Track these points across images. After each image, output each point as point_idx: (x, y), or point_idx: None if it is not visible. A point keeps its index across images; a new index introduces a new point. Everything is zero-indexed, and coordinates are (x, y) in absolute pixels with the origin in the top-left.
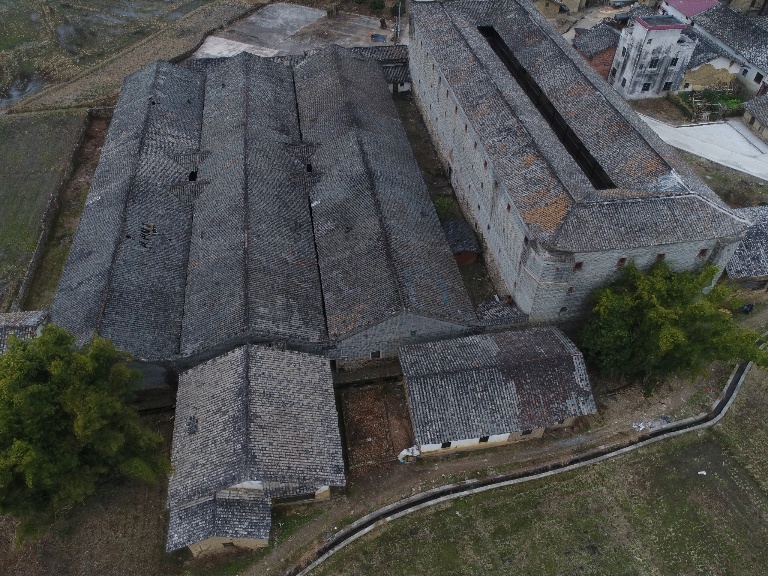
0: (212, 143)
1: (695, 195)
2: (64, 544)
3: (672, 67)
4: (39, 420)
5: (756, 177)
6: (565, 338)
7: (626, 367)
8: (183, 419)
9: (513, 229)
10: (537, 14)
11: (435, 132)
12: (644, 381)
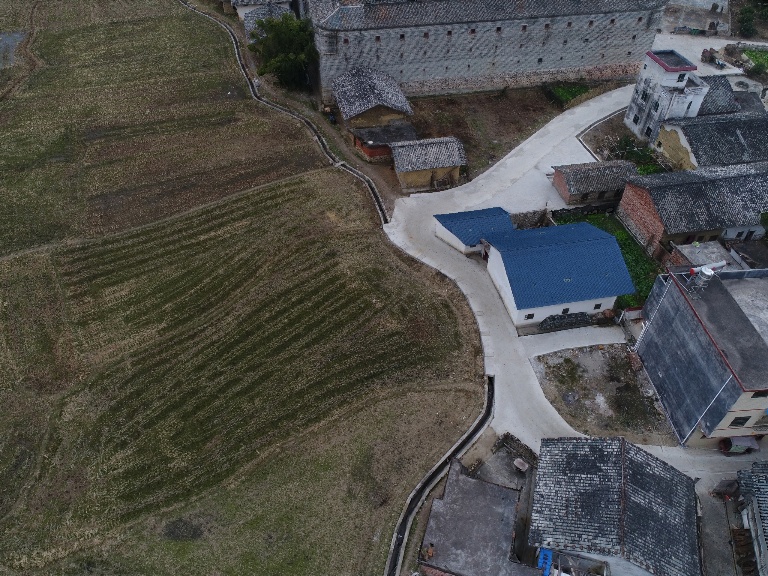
0: None
1: None
2: None
3: (655, 112)
4: None
5: None
6: None
7: None
8: None
9: None
10: (624, 2)
11: None
12: None
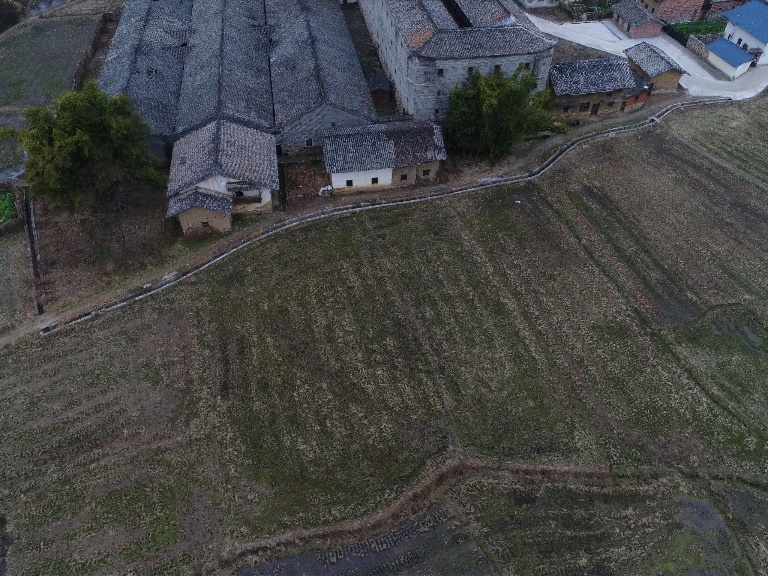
0: (198, 25)
1: (521, 27)
2: (101, 232)
3: None
4: (90, 123)
5: (610, 53)
6: (433, 122)
7: (475, 143)
8: (177, 159)
9: (404, 59)
10: None
11: (370, 24)
12: (490, 157)
